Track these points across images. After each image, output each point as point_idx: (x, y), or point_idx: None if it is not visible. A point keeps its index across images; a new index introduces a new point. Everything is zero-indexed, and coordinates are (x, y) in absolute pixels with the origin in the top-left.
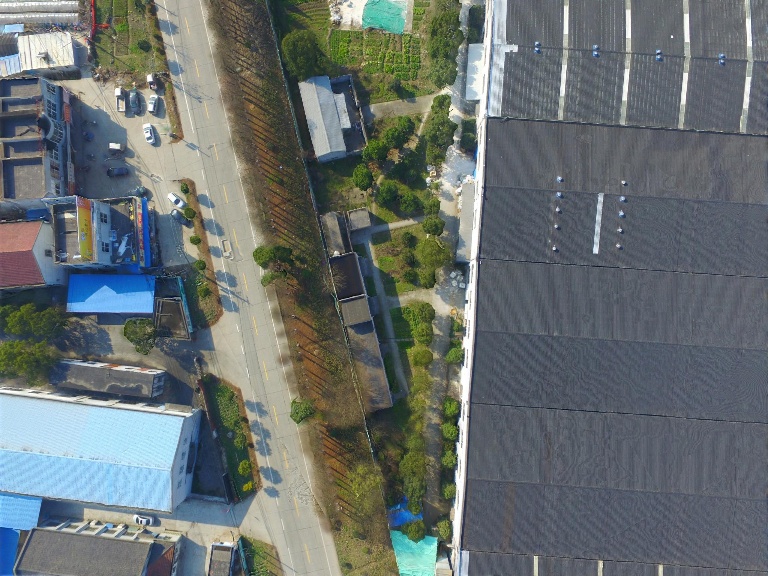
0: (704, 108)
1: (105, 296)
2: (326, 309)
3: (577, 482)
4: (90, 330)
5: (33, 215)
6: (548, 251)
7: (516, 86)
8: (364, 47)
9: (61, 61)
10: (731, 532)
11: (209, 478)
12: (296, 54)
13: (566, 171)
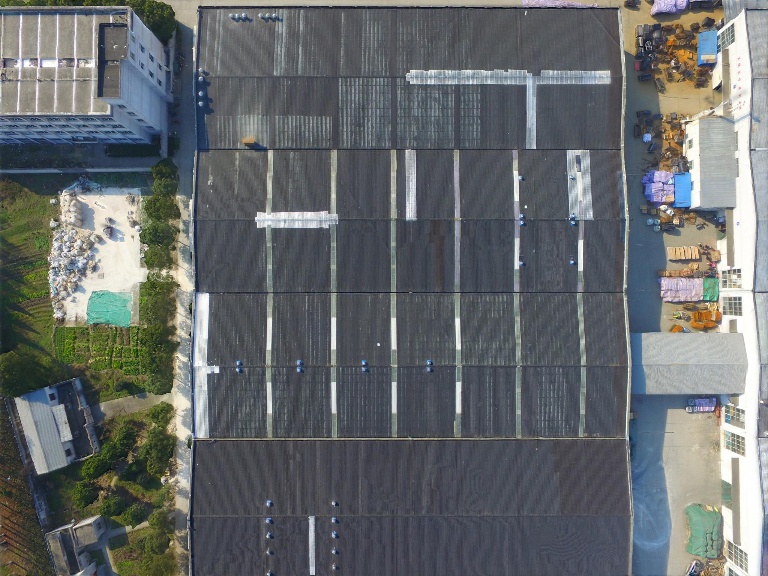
0: (416, 415)
1: None
2: None
3: None
4: None
5: None
6: None
7: (221, 407)
8: (91, 343)
9: None
10: None
11: None
12: None
13: (277, 493)
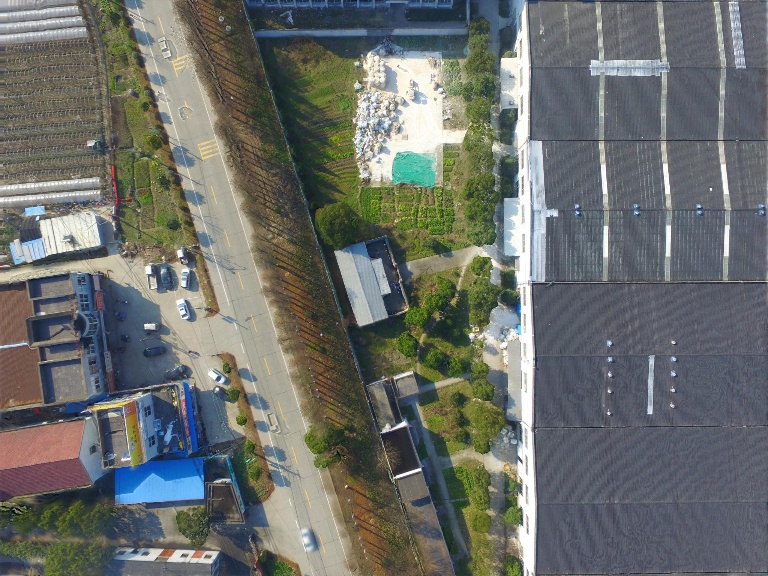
0: (747, 259)
1: (153, 485)
2: (379, 477)
3: None
4: (139, 515)
5: (73, 410)
6: (602, 416)
7: (559, 250)
8: (396, 203)
9: (87, 243)
10: None
11: None
12: (333, 231)
13: (615, 334)
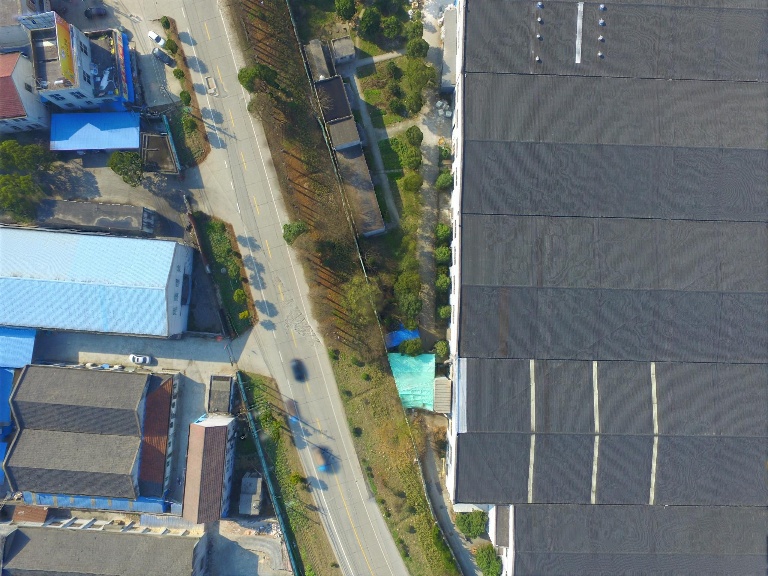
0: None
1: (89, 133)
2: (314, 141)
3: (569, 283)
4: (75, 174)
5: (10, 51)
6: (531, 62)
7: None
8: None
9: None
10: (719, 326)
11: (204, 316)
12: None
13: None
